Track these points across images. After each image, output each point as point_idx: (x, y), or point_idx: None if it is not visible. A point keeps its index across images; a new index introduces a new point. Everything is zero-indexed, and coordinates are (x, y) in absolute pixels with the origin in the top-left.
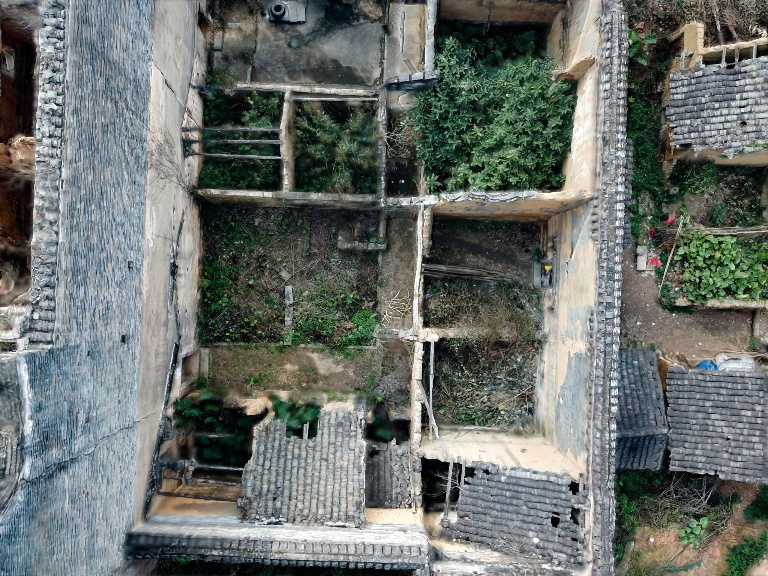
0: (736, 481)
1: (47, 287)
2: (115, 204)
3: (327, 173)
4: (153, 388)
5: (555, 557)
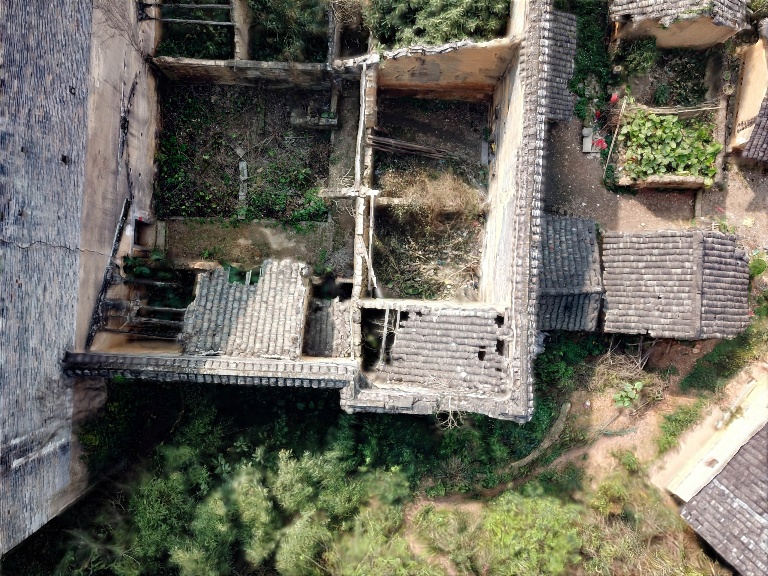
0: (666, 338)
1: None
2: (54, 21)
3: (281, 51)
4: (100, 228)
5: (480, 388)
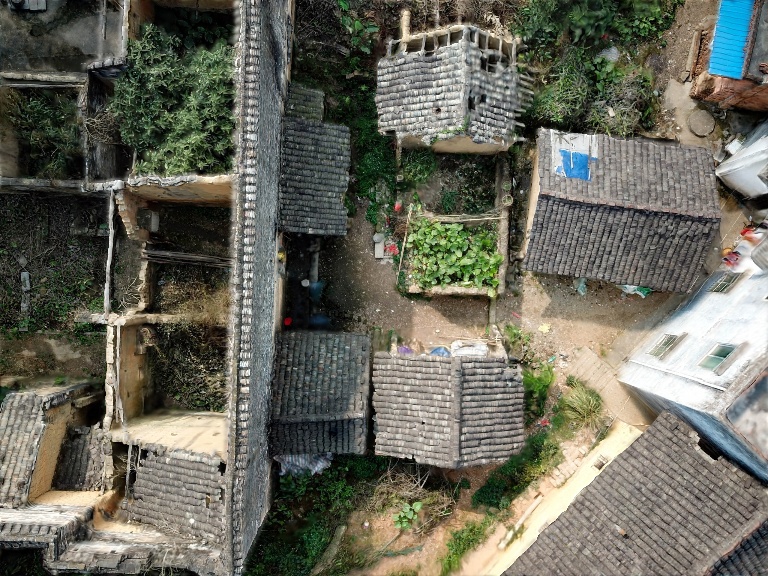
0: (430, 465)
1: None
2: None
3: None
4: None
5: (205, 537)
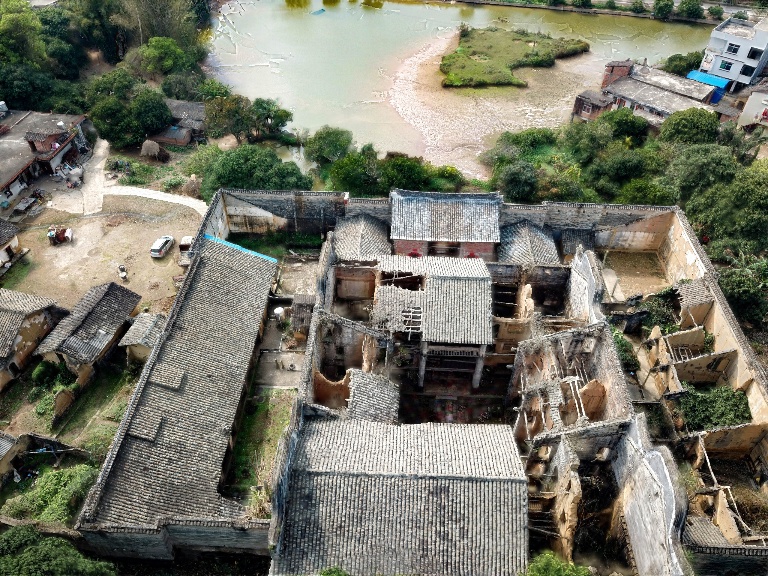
0: None
1: (632, 408)
2: None
3: None
4: None
5: None
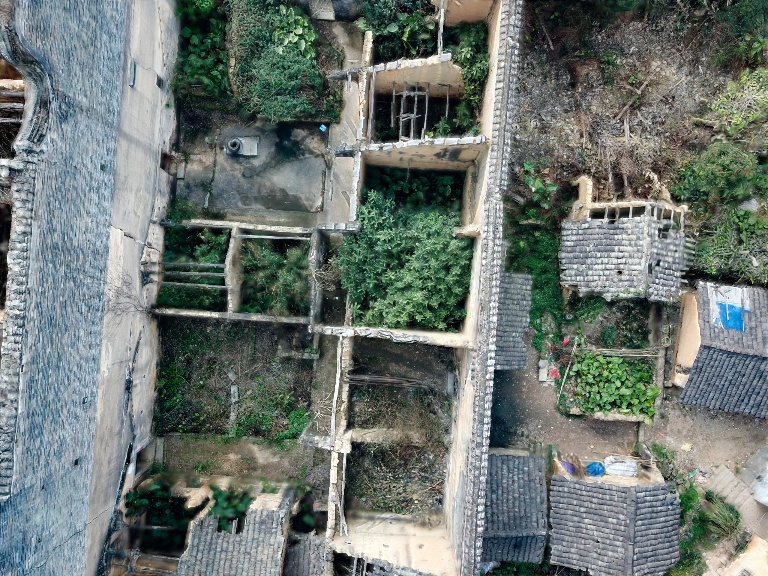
0: None
1: (7, 451)
2: (71, 359)
3: None
4: (106, 490)
5: None
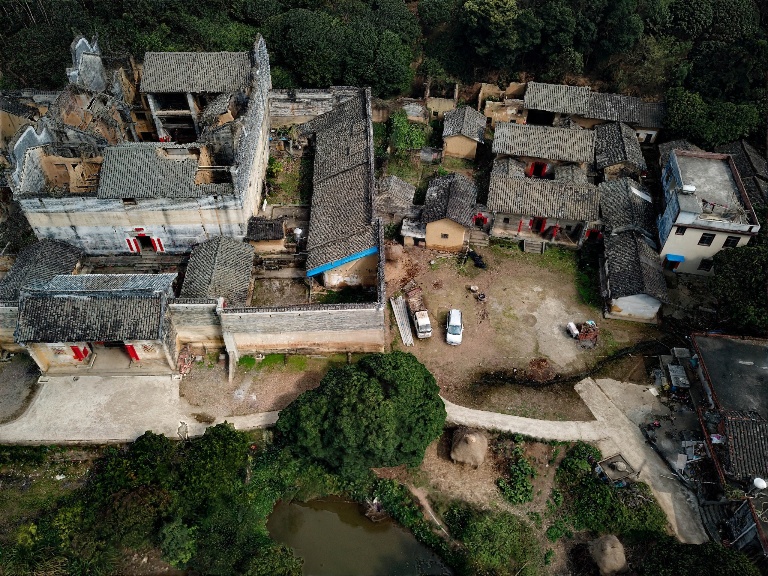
0: None
1: None
2: None
3: None
4: None
5: (6, 99)
